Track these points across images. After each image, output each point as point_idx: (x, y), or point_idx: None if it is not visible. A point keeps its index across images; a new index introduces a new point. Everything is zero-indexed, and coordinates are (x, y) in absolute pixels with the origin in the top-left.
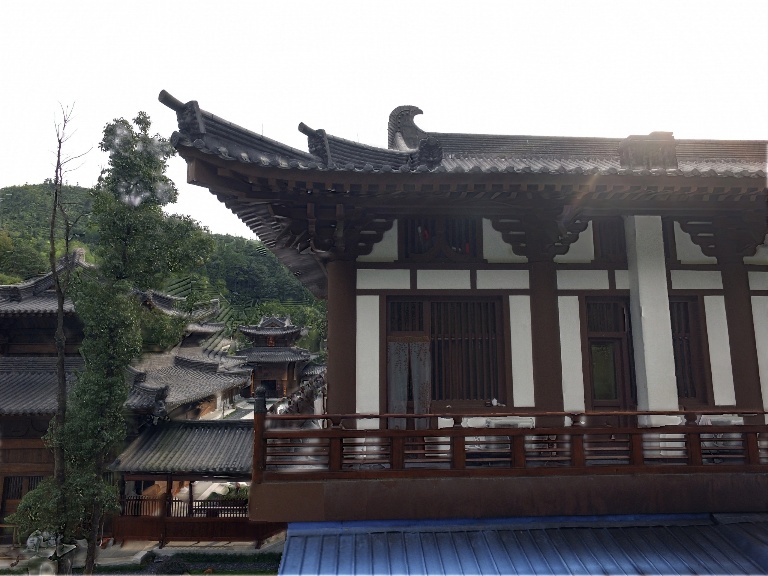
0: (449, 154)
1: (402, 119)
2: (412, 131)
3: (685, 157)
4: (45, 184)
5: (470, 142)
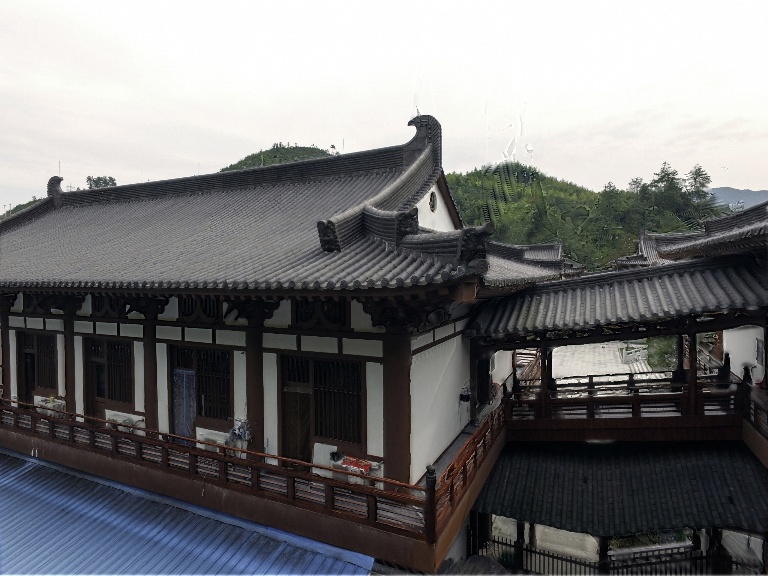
0: (71, 206)
1: (52, 186)
2: (56, 193)
3: (179, 193)
4: (273, 149)
5: (78, 197)
